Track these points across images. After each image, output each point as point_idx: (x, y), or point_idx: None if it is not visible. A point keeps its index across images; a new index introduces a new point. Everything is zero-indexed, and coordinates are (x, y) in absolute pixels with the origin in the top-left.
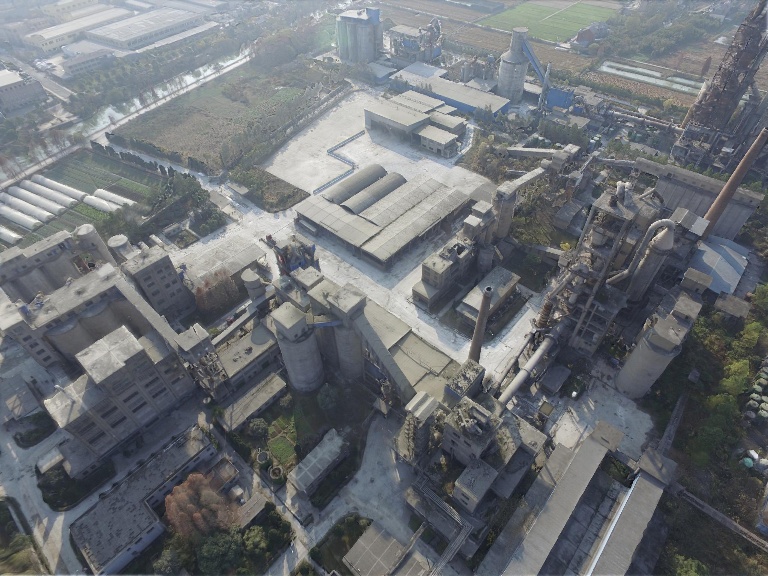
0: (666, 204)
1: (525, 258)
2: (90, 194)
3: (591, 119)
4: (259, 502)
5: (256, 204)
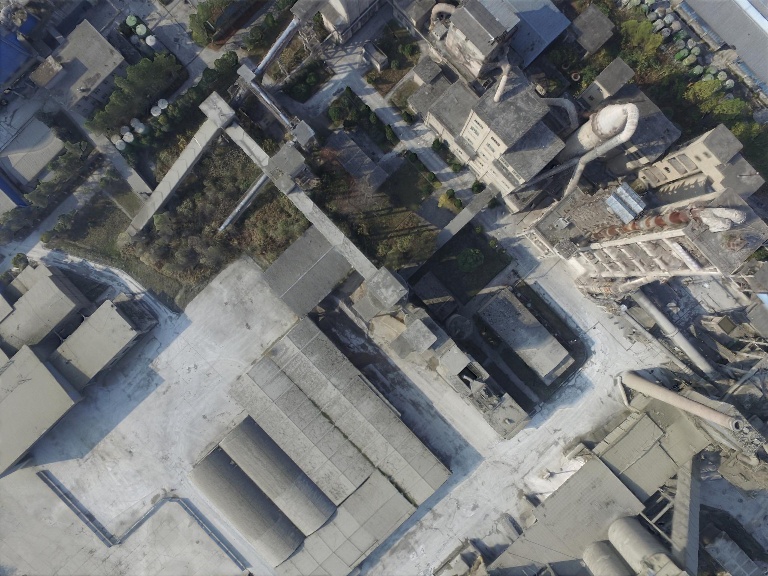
0: (367, 4)
1: None
2: None
3: (60, 8)
4: None
5: None
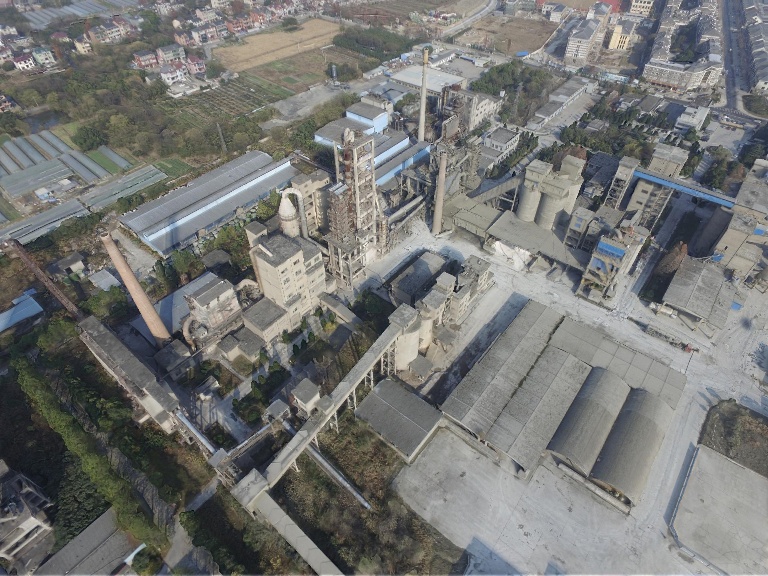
0: None
1: None
2: None
3: None
4: None
5: None
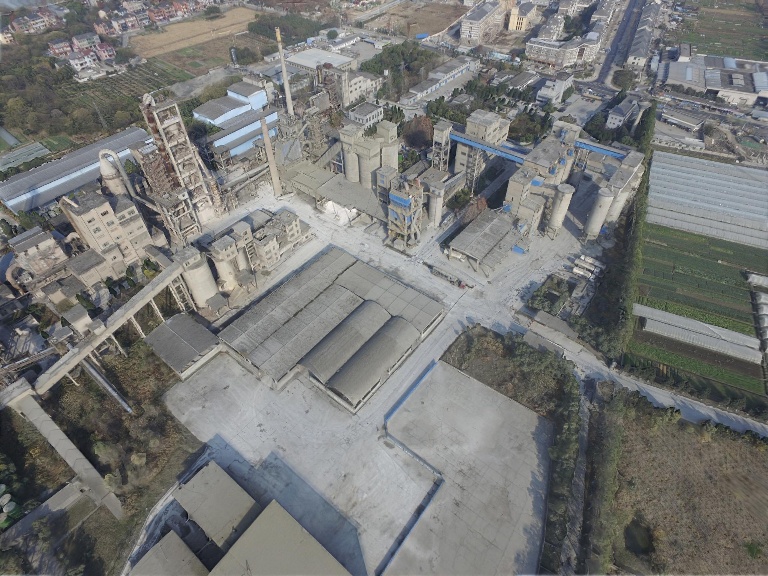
0: None
1: None
2: (767, 354)
3: None
4: None
5: None
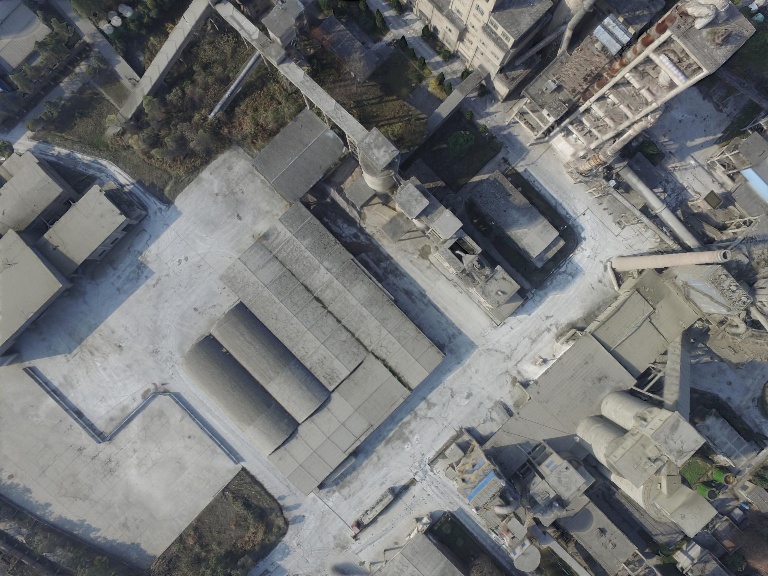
0: None
1: (457, 152)
2: None
3: None
4: (759, 493)
5: (260, 558)
